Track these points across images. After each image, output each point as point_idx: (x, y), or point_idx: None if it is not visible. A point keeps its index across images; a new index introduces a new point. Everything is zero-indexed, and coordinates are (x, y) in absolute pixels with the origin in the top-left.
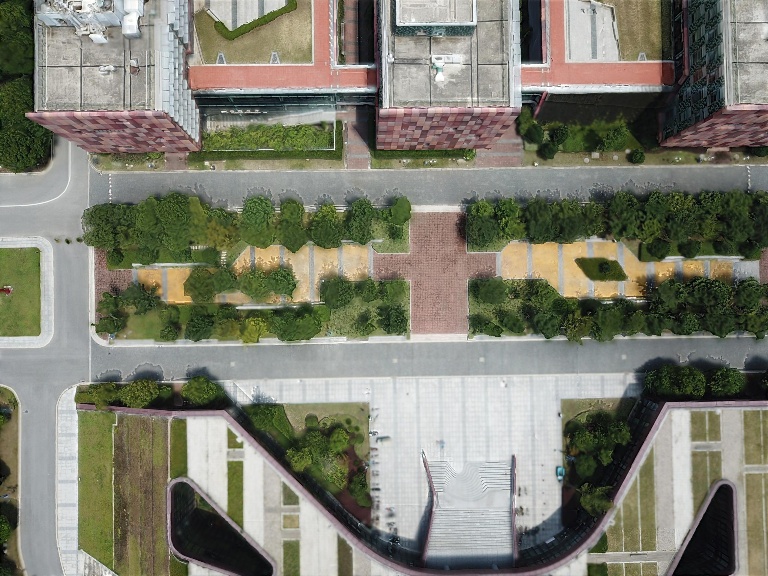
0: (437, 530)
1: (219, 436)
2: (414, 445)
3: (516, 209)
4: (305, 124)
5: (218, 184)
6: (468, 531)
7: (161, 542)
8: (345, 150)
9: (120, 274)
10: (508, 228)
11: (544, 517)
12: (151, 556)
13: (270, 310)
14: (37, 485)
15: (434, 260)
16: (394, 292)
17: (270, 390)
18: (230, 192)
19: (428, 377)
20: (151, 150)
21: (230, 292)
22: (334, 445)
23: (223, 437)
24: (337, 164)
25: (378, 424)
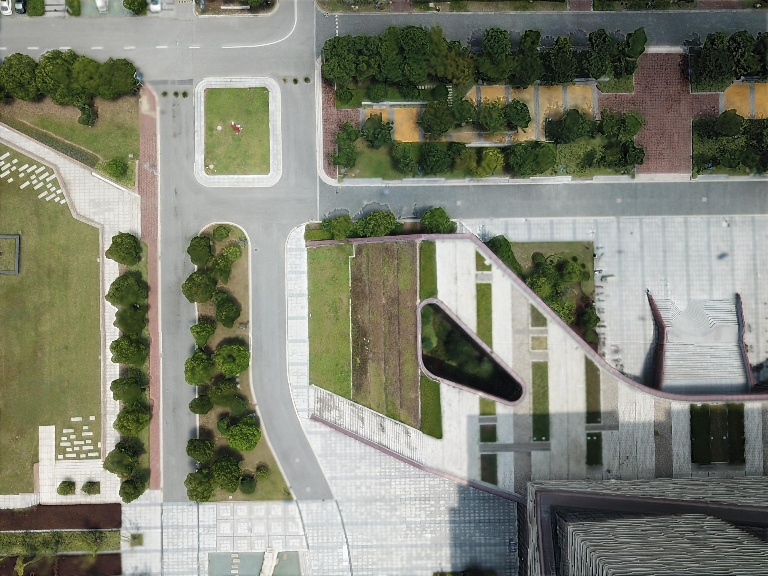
0: (669, 362)
1: (467, 259)
2: (639, 283)
3: (753, 39)
4: None
5: (442, 26)
6: (700, 363)
7: (410, 364)
8: None
9: (348, 114)
10: (744, 59)
11: (767, 355)
12: (397, 380)
13: (497, 148)
14: (267, 322)
15: (658, 100)
16: None
17: (496, 229)
18: (454, 33)
19: (651, 217)
20: None
21: (456, 131)
22: (569, 277)
23: (471, 260)
24: (560, 6)
25: (603, 263)
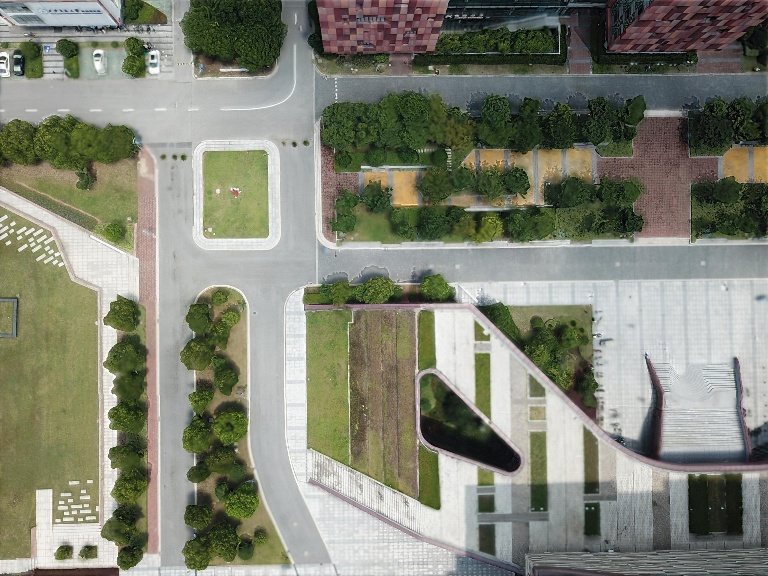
0: (667, 428)
1: (466, 329)
2: (637, 347)
3: (752, 108)
4: (527, 29)
5: (442, 89)
6: (698, 429)
7: (408, 433)
8: (567, 55)
9: (347, 177)
10: (743, 127)
11: (765, 419)
12: (396, 448)
13: (496, 212)
14: (266, 385)
15: (657, 164)
16: (629, 191)
17: (494, 293)
18: (454, 96)
19: (650, 280)
20: (387, 50)
21: (455, 195)
22: (567, 343)
23: (470, 330)
24: (559, 69)
25: (601, 327)
